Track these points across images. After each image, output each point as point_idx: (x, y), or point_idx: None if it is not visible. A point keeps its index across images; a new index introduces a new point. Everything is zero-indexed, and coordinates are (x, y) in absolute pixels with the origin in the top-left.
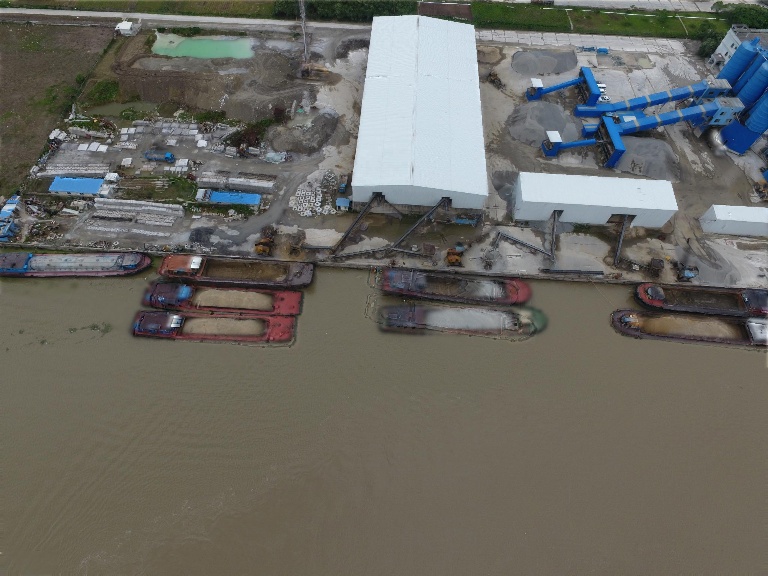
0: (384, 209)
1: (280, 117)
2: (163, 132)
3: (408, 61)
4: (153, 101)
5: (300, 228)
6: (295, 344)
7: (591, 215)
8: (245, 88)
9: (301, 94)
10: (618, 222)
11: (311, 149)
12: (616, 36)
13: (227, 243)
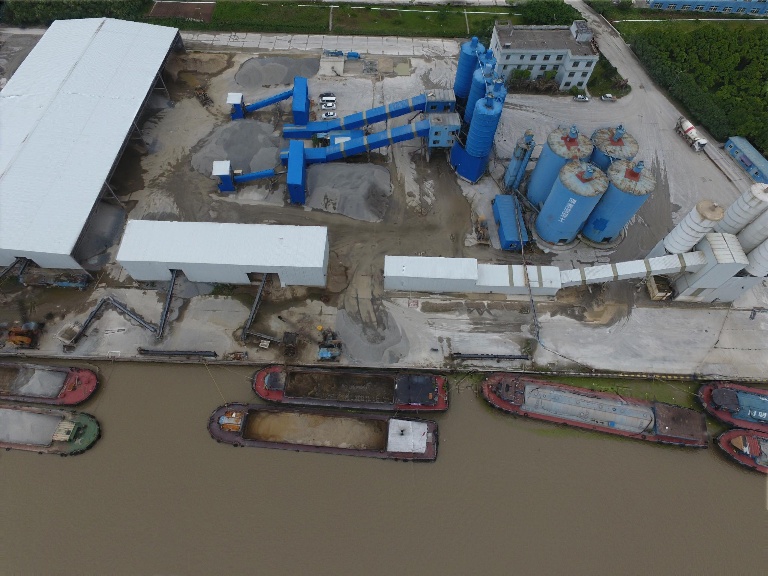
0: None
1: None
2: None
3: (57, 76)
4: None
5: None
6: None
7: (222, 274)
8: None
9: None
10: (266, 280)
11: None
12: (382, 37)
13: None
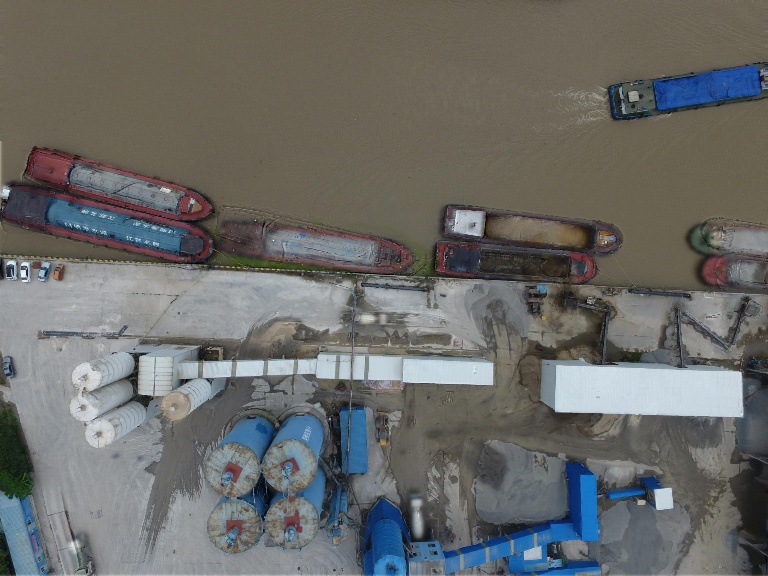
0: None
1: None
2: None
3: None
4: None
5: None
6: None
7: None
8: None
9: None
10: None
11: None
12: None
13: None
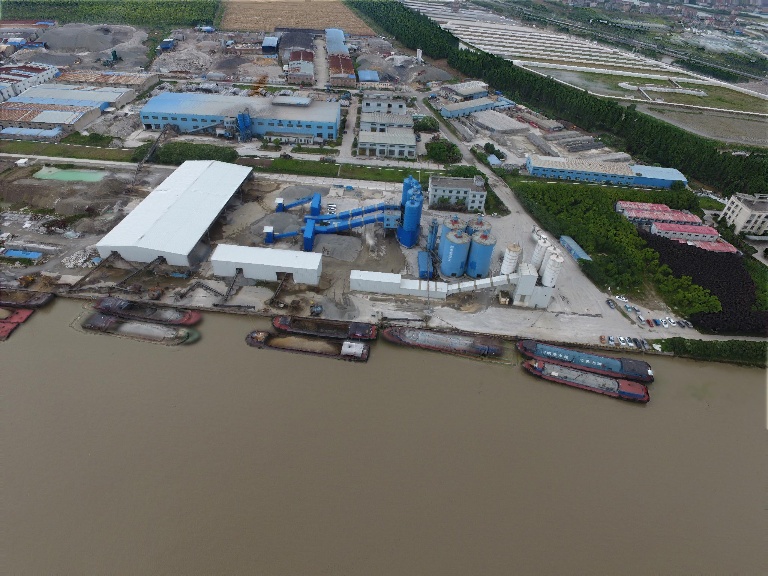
0: (125, 265)
1: (91, 213)
2: (5, 219)
3: (187, 183)
4: (11, 202)
5: (60, 274)
6: (8, 340)
7: (263, 273)
8: (76, 196)
9: (116, 202)
10: (286, 279)
11: (100, 231)
12: (368, 181)
13: (1, 280)
